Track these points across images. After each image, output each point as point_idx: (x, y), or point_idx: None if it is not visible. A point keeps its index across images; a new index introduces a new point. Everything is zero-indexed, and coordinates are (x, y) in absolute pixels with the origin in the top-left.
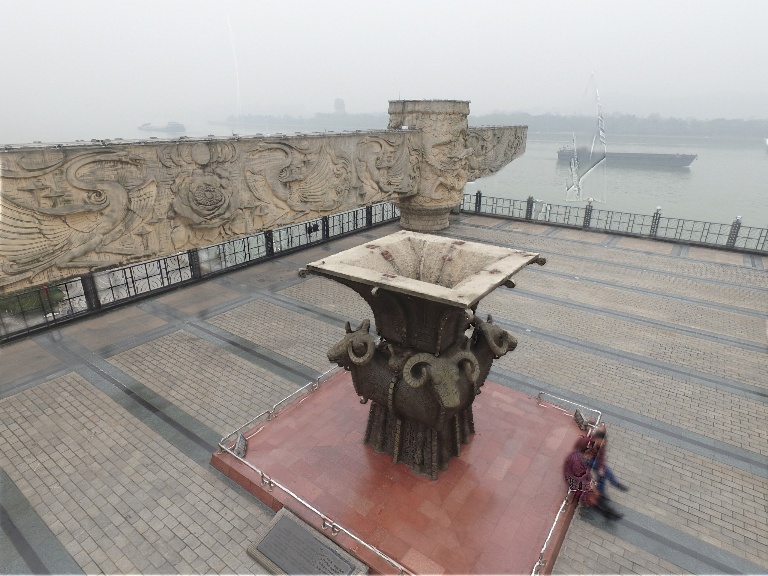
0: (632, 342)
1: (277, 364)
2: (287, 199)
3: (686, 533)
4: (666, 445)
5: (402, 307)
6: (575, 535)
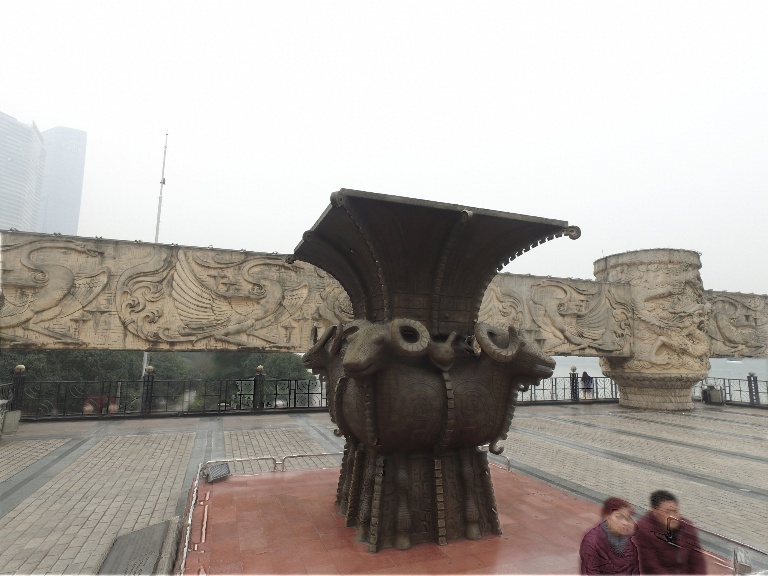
0: None
1: None
2: None
3: None
4: None
5: (357, 274)
6: None
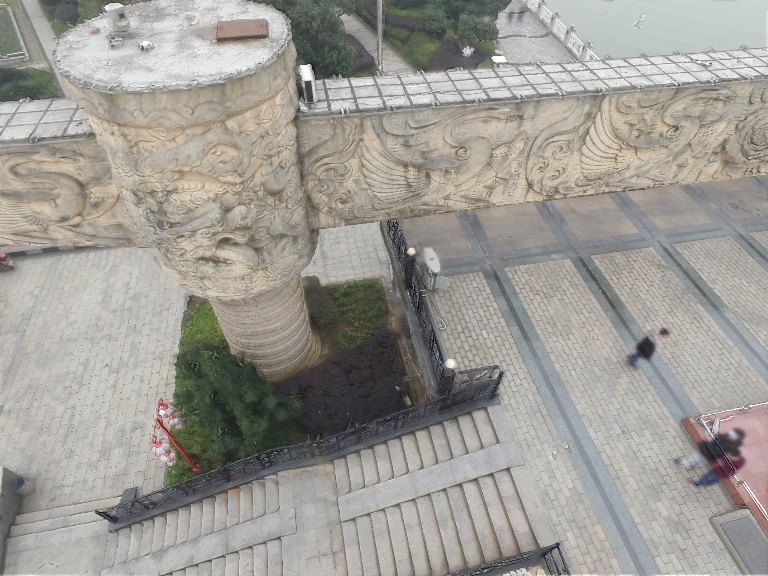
0: None
1: (745, 342)
2: None
3: None
4: None
5: None
6: None
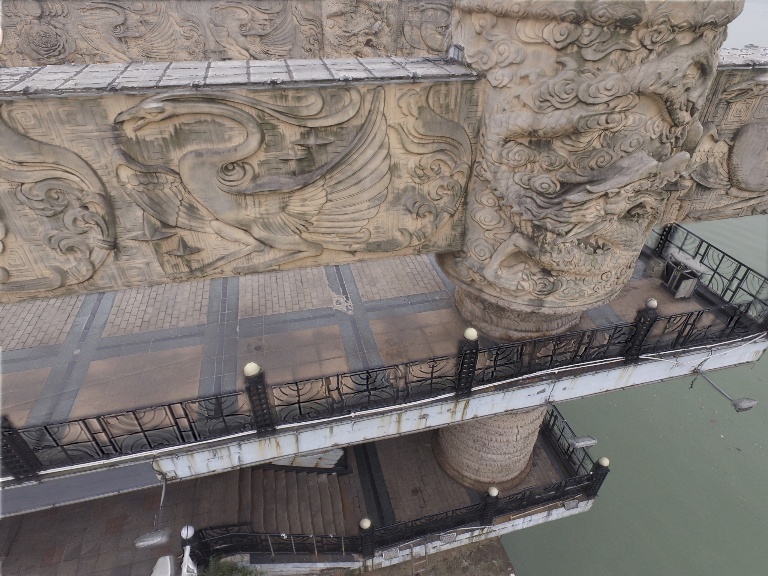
0: None
1: None
2: (125, 52)
3: None
4: None
5: None
6: None
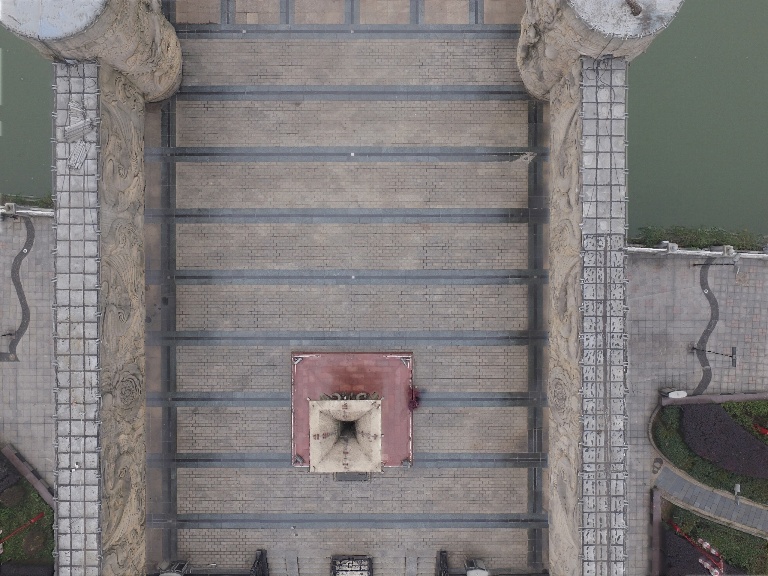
0: (409, 255)
1: (257, 400)
2: None
3: (445, 392)
4: (435, 348)
5: None
6: (415, 414)
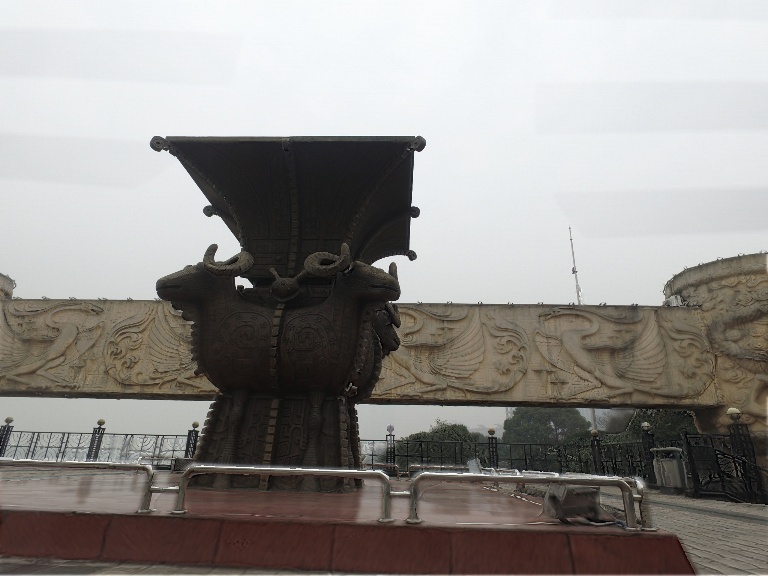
0: None
1: None
2: None
3: None
4: None
5: None
6: None
